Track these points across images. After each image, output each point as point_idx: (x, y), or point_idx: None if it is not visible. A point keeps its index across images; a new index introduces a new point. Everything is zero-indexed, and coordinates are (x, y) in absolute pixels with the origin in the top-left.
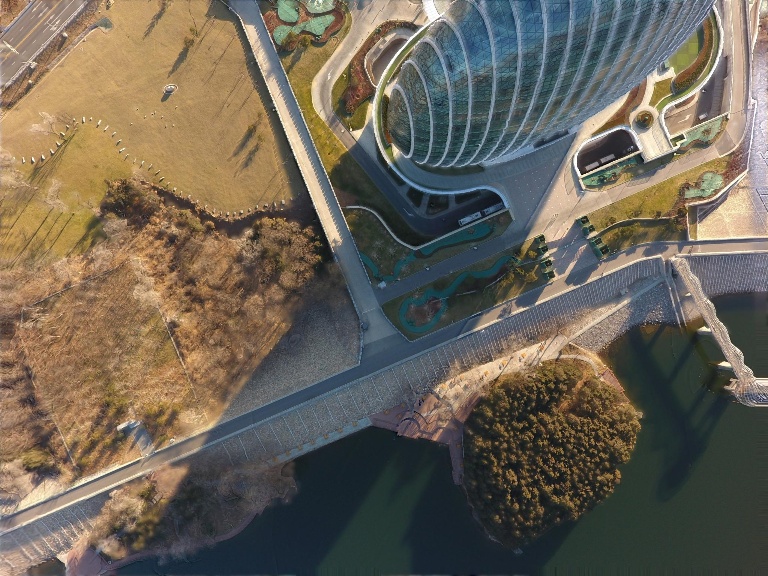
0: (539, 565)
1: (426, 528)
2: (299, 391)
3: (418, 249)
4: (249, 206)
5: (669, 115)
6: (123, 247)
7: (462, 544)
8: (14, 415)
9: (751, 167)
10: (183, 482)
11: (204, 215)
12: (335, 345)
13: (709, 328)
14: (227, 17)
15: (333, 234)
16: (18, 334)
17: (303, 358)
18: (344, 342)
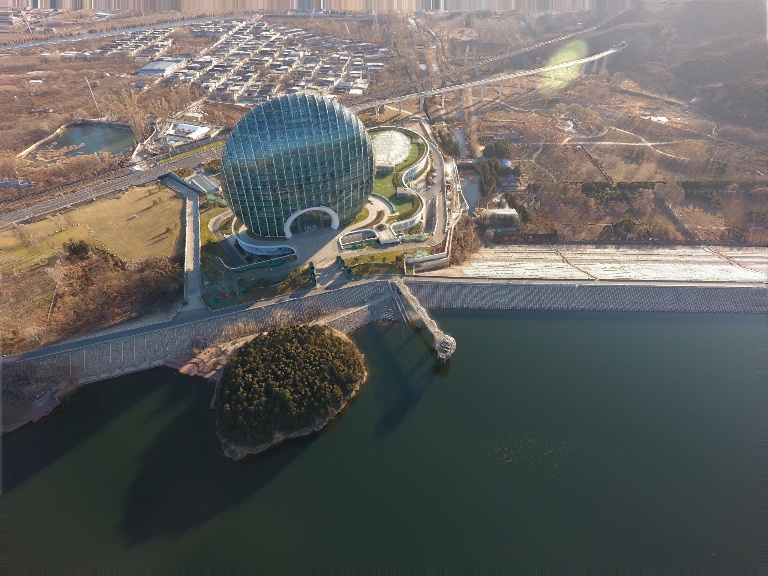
0: (263, 482)
1: (172, 445)
2: (119, 332)
3: (236, 269)
4: None
5: None
6: None
7: (198, 460)
8: None
9: None
10: None
11: None
12: None
13: None
14: (181, 198)
15: (190, 267)
16: None
17: (135, 323)
18: None
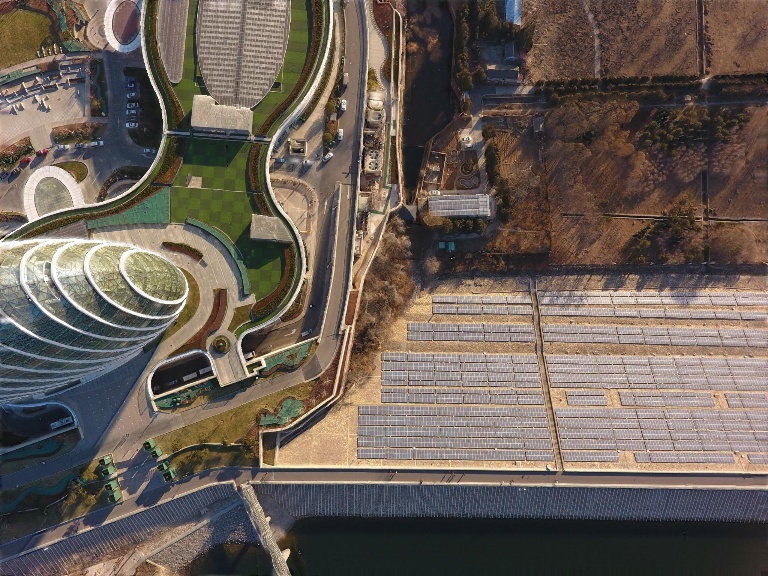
0: None
1: None
2: None
3: None
4: None
5: (276, 328)
6: None
7: None
8: None
9: (365, 380)
10: None
11: None
12: None
13: None
14: None
15: None
16: None
17: None
18: None
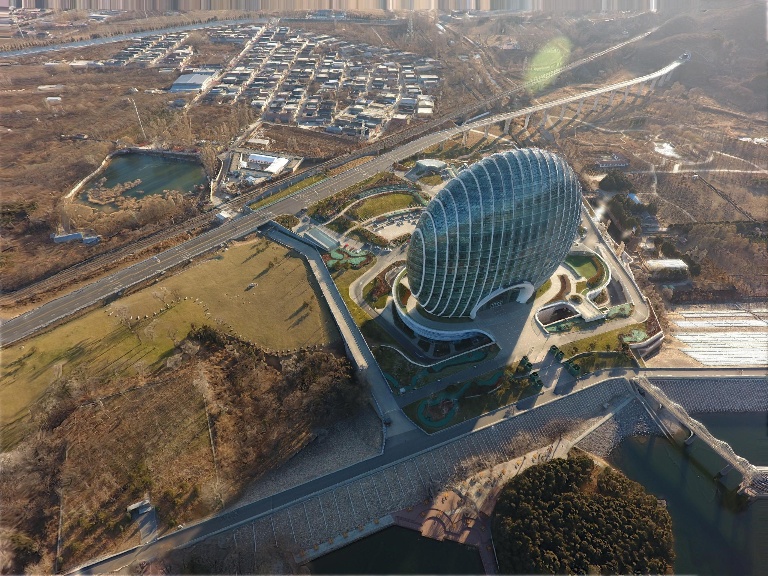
0: None
1: None
2: (323, 476)
3: (430, 366)
4: (295, 347)
5: None
6: (188, 368)
7: None
8: (34, 479)
9: (669, 341)
10: (184, 561)
11: (258, 352)
12: (359, 444)
13: (690, 430)
14: (298, 257)
15: (361, 362)
16: (74, 414)
17: (328, 455)
18: (368, 441)
